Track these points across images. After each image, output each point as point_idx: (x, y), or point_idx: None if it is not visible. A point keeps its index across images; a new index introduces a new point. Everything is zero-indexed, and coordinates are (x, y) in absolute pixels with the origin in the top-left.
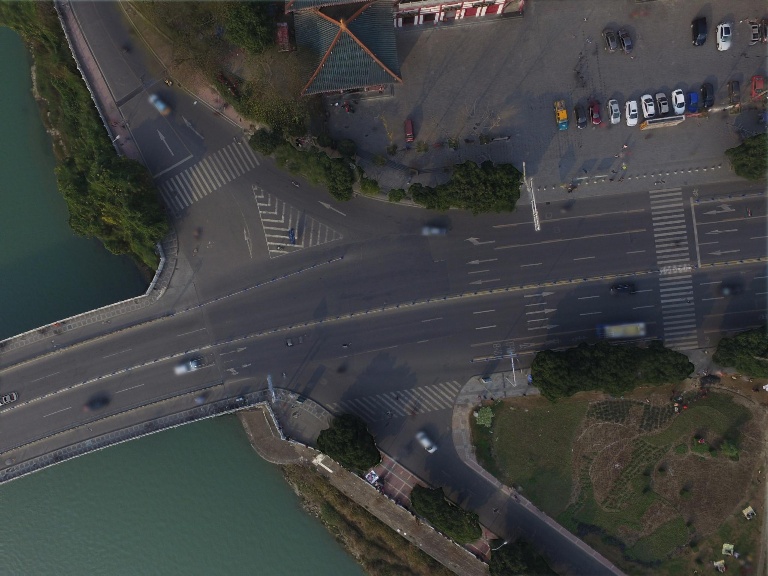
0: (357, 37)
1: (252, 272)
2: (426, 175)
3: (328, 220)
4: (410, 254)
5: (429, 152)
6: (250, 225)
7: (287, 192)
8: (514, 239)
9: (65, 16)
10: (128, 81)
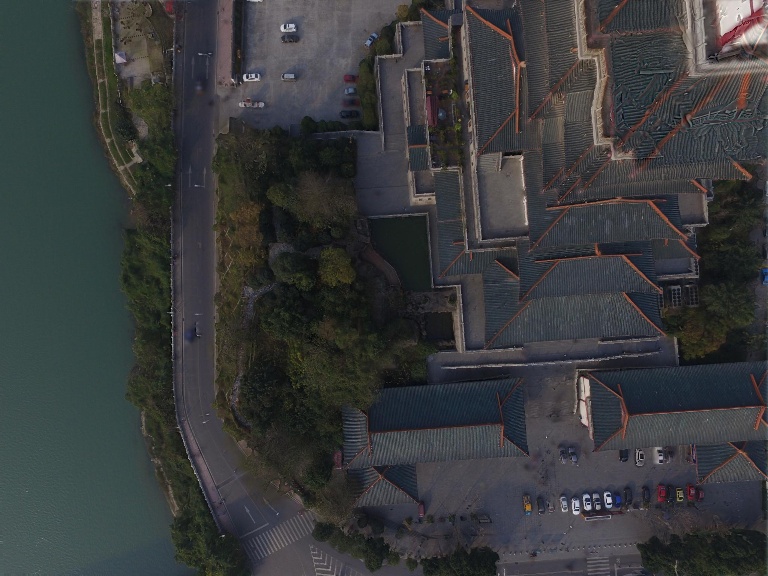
0: (390, 479)
1: None
2: (432, 541)
3: (362, 570)
4: None
5: (435, 523)
6: (307, 572)
7: (334, 550)
8: None
9: (184, 428)
10: (226, 472)
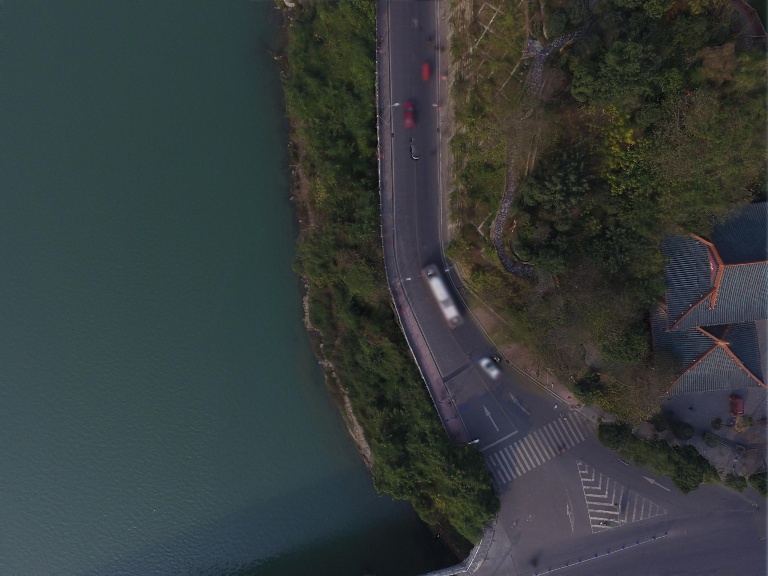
0: None
1: (573, 546)
2: (753, 451)
3: (652, 495)
4: (736, 531)
5: (754, 426)
6: (573, 500)
7: (612, 467)
8: None
9: (396, 294)
10: (456, 358)
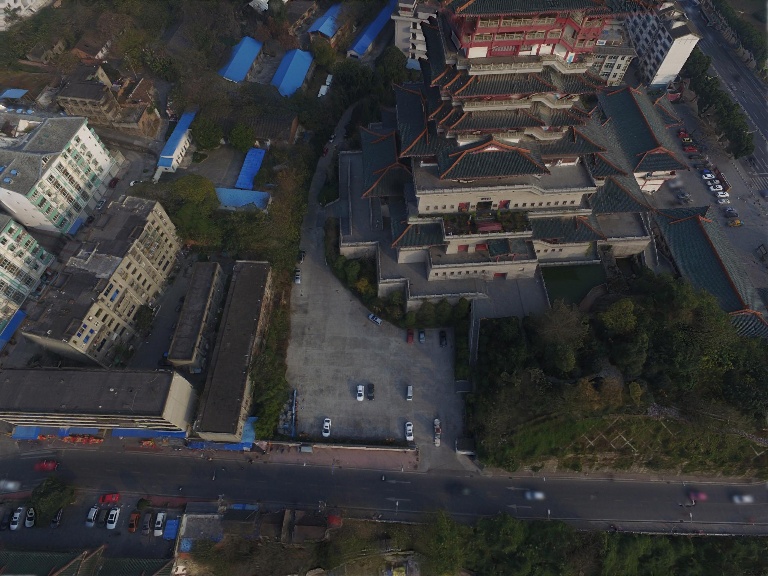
0: None
1: None
2: None
3: None
4: None
5: None
6: None
7: None
8: None
9: None
10: None
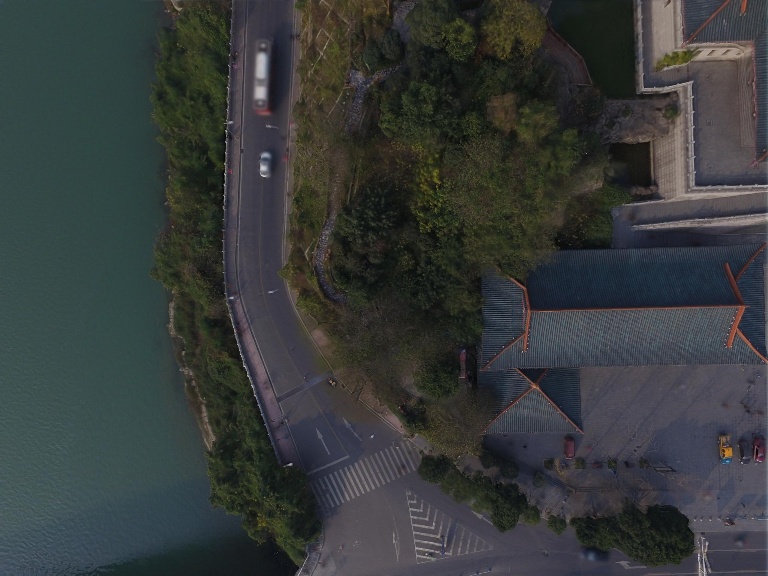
0: (545, 391)
1: (397, 575)
2: (582, 494)
3: (479, 530)
4: (559, 572)
5: (587, 470)
6: (400, 529)
7: (441, 499)
8: (666, 567)
9: (235, 310)
10: (291, 378)
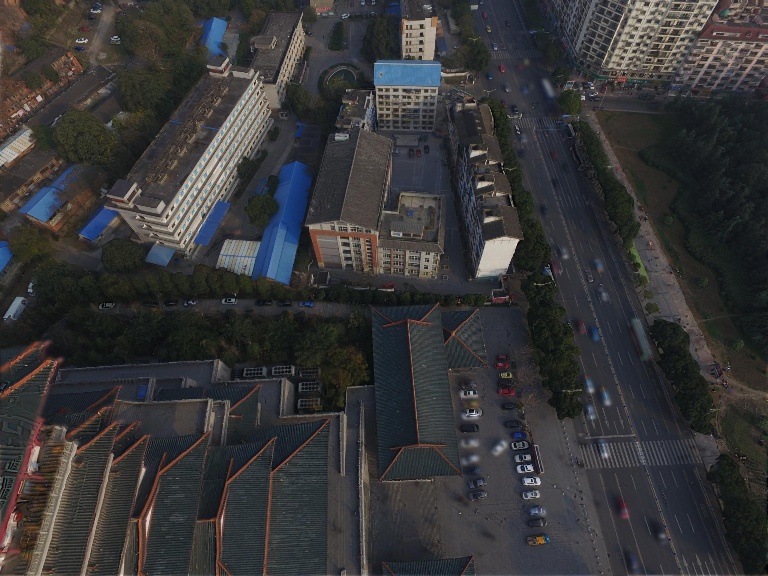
0: None
1: None
2: None
3: None
4: None
5: None
6: None
7: None
8: None
9: None
10: None
